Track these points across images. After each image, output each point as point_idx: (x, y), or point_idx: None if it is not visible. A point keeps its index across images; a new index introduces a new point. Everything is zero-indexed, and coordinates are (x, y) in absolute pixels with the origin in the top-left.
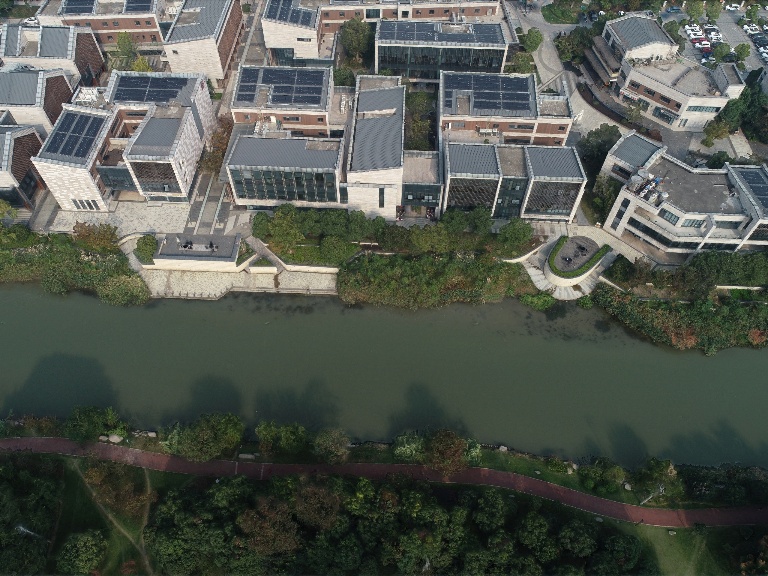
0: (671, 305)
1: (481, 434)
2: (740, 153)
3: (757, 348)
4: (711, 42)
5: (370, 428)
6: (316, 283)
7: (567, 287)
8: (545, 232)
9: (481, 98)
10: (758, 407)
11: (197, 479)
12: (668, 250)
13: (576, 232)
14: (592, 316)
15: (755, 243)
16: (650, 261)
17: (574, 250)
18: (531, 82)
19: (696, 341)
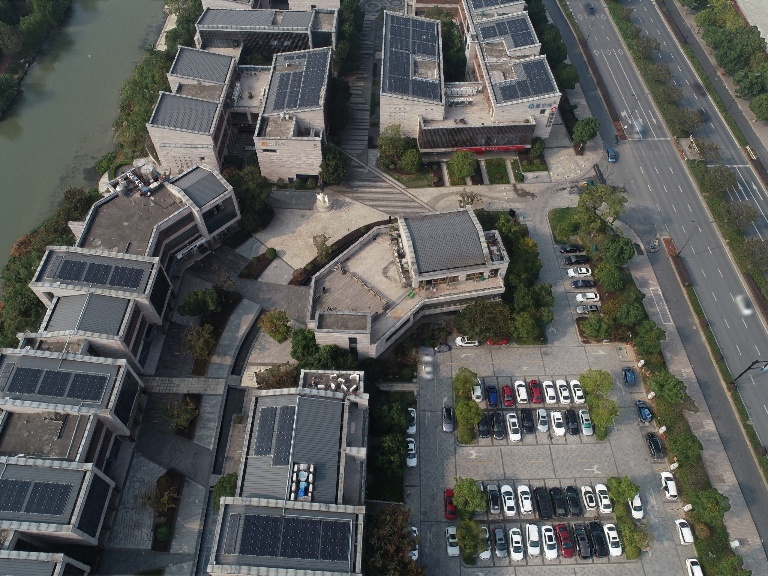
0: None
1: (5, 125)
2: None
3: None
4: None
5: (36, 76)
6: (163, 48)
7: None
8: None
9: (293, 77)
10: None
11: (22, 3)
12: None
13: None
14: None
15: None
16: (76, 198)
17: None
18: None
19: (12, 255)
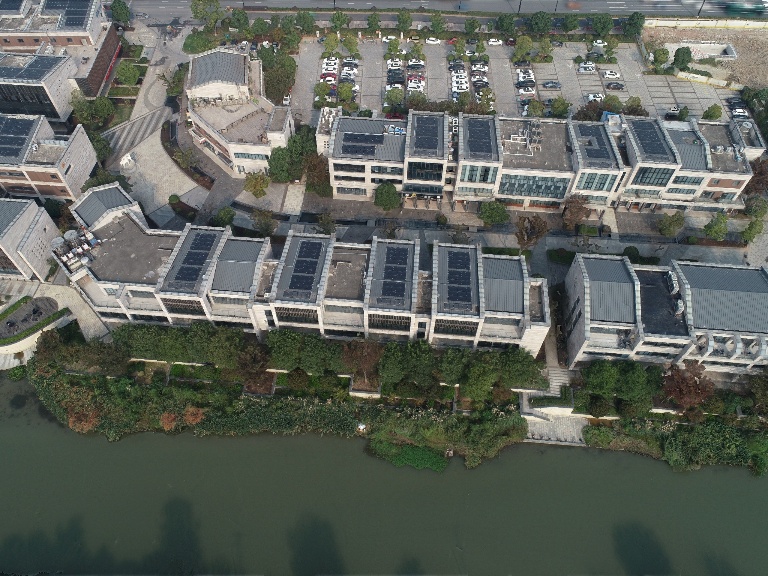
0: (90, 382)
1: None
2: (287, 205)
3: (170, 434)
4: (341, 78)
5: None
6: None
7: (8, 354)
8: (11, 291)
9: None
10: (128, 505)
11: None
12: (103, 319)
13: (45, 292)
14: (15, 389)
15: (182, 316)
16: (56, 334)
17: (28, 313)
18: (37, 125)
19: (94, 425)
